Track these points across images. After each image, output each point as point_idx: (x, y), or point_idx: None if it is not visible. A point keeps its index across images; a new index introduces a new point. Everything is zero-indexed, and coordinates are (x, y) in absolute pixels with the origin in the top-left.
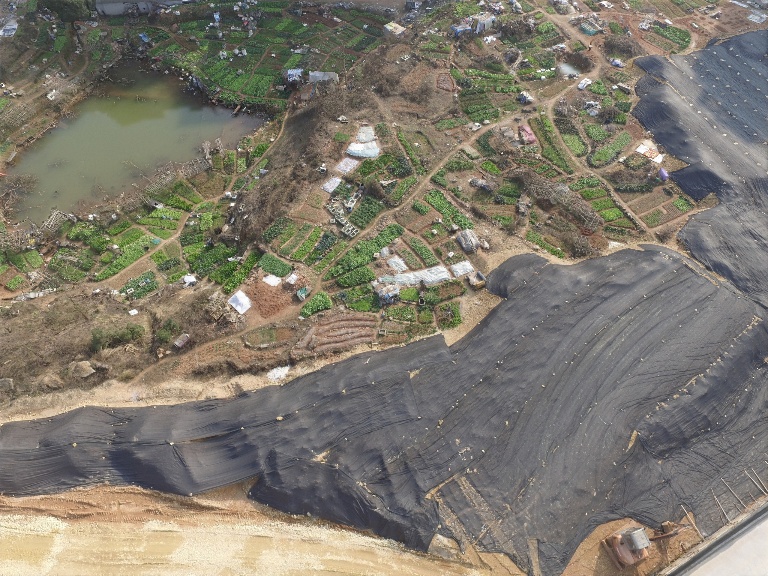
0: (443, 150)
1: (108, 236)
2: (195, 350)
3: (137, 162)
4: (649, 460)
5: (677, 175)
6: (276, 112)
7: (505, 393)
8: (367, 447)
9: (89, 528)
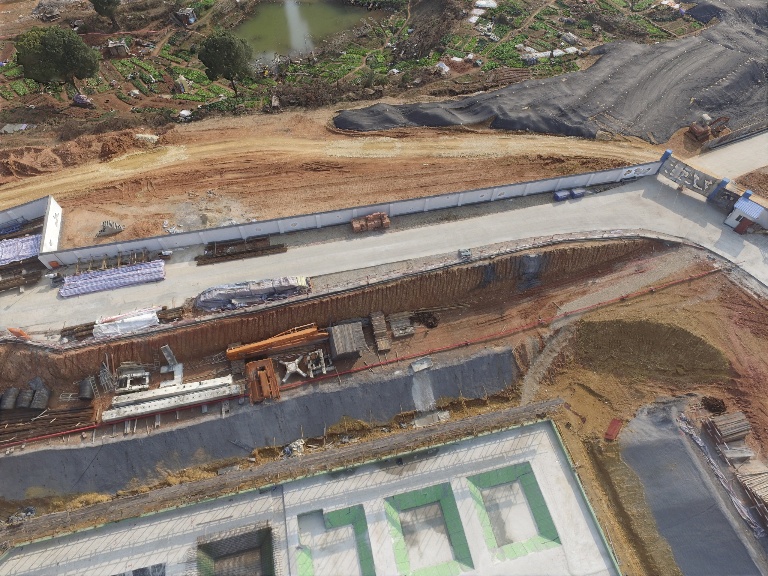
0: (536, 6)
1: None
2: (427, 85)
3: None
4: (702, 111)
5: (691, 11)
6: (400, 6)
7: (617, 87)
8: (550, 103)
9: (411, 140)
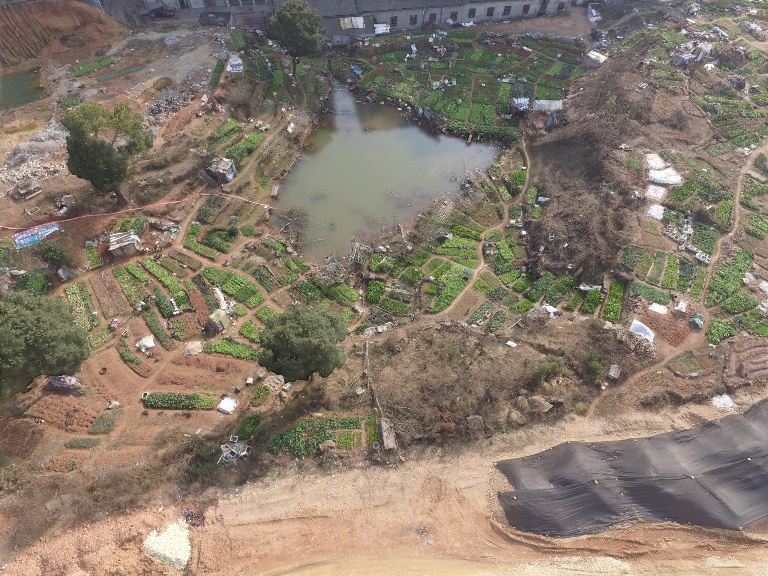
0: (731, 175)
1: (414, 267)
2: (630, 381)
3: (399, 192)
4: None
5: None
6: (511, 140)
7: None
8: None
9: (653, 567)
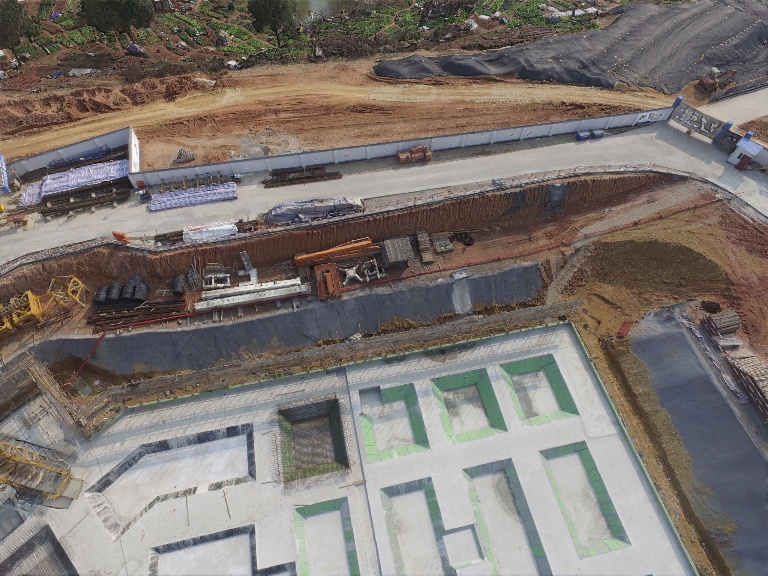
0: None
1: None
2: (457, 40)
3: None
4: (711, 66)
5: None
6: None
7: (634, 43)
8: (573, 56)
9: (445, 87)
